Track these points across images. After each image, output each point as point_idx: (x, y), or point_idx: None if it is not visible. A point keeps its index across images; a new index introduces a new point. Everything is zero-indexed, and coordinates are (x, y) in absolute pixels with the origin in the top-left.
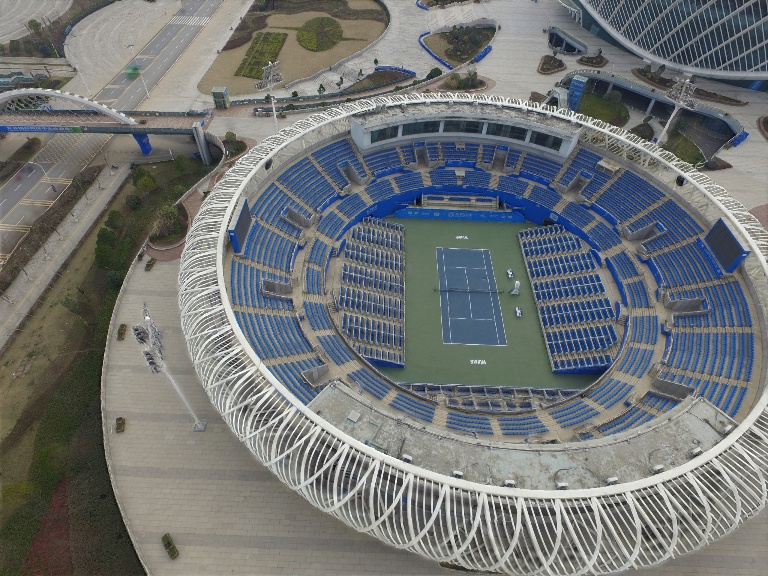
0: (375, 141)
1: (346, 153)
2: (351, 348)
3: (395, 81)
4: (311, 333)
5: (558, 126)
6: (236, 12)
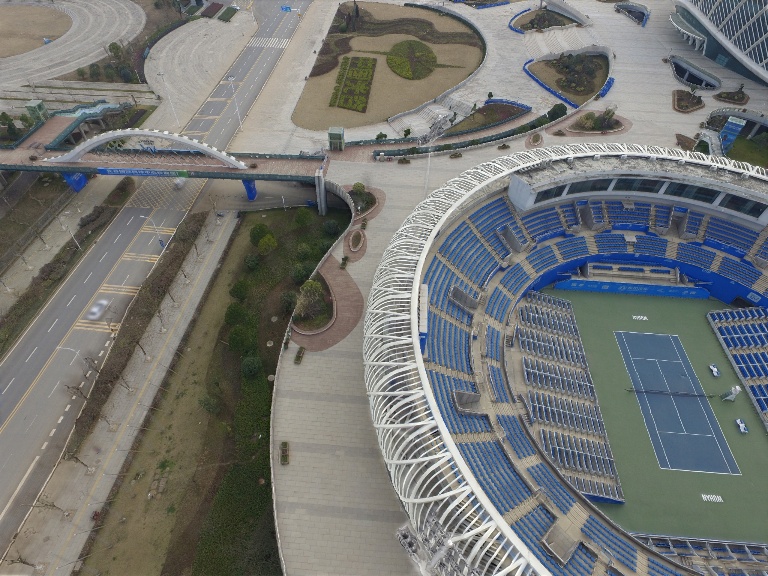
0: (537, 201)
1: (503, 214)
2: (568, 484)
3: (513, 117)
4: (518, 463)
5: (761, 189)
6: (316, 33)
